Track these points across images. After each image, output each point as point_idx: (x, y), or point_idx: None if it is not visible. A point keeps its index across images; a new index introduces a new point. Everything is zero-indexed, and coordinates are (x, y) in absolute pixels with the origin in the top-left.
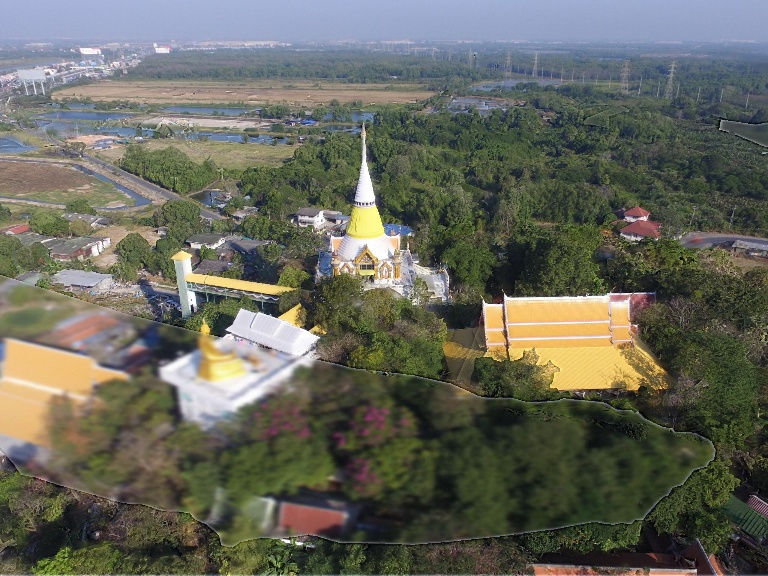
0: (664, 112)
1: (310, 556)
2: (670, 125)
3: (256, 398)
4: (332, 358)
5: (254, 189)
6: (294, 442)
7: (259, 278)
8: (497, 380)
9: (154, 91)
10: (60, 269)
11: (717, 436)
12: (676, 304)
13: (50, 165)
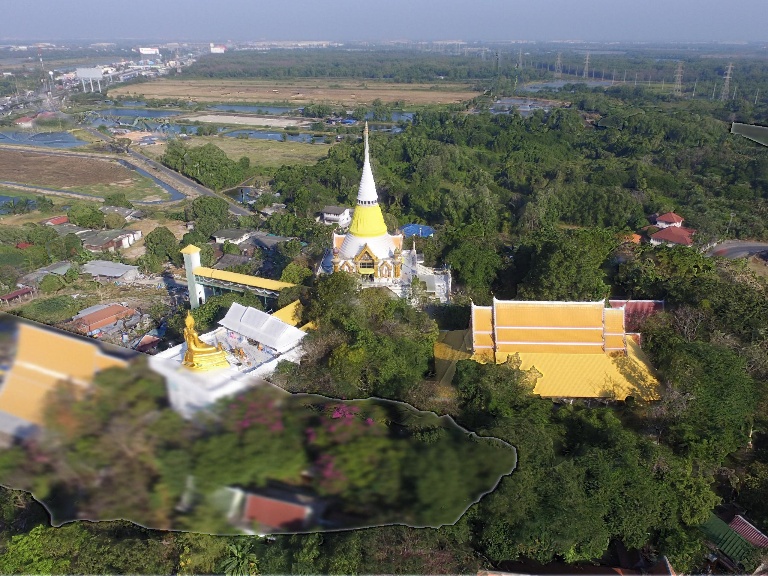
0: (716, 115)
1: (268, 548)
2: (720, 128)
3: (73, 383)
4: (316, 354)
5: (284, 186)
6: (108, 428)
7: (275, 274)
8: (476, 383)
9: (204, 90)
10: (90, 259)
11: (695, 451)
12: (681, 313)
13: (97, 160)
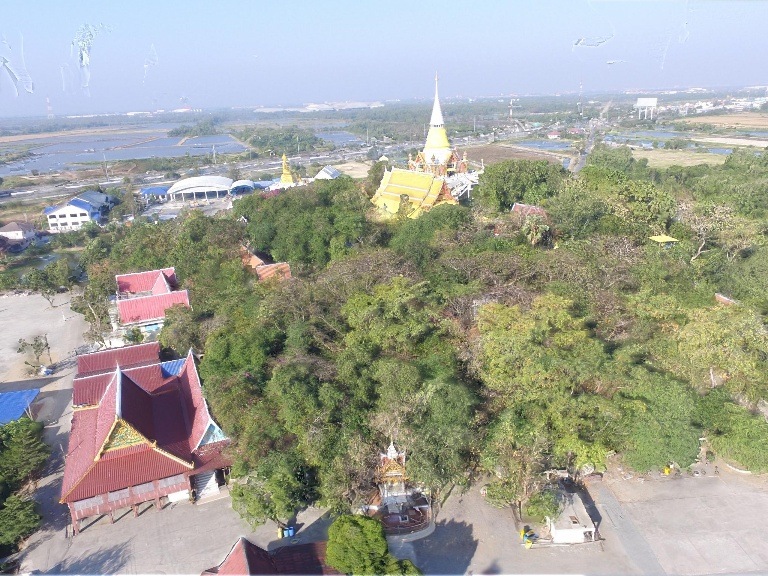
0: None
1: None
2: None
3: None
4: None
5: None
6: None
7: None
8: None
9: None
10: None
11: None
12: (525, 207)
13: (553, 157)
